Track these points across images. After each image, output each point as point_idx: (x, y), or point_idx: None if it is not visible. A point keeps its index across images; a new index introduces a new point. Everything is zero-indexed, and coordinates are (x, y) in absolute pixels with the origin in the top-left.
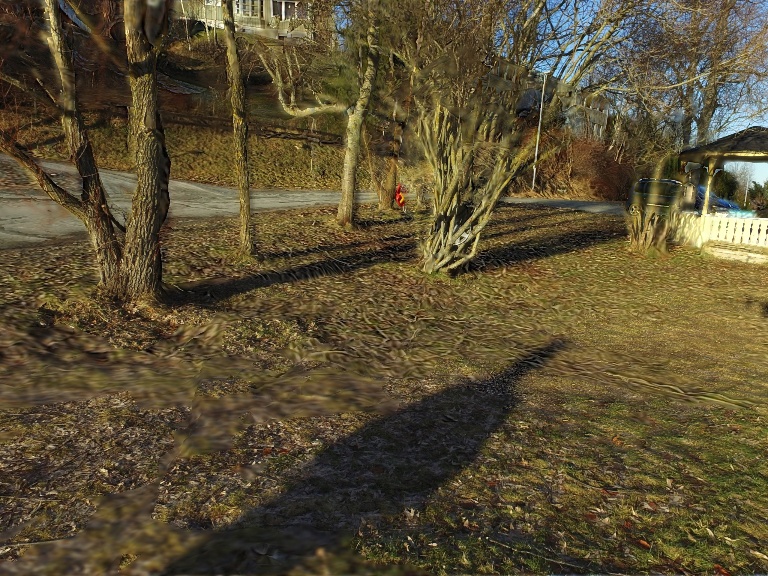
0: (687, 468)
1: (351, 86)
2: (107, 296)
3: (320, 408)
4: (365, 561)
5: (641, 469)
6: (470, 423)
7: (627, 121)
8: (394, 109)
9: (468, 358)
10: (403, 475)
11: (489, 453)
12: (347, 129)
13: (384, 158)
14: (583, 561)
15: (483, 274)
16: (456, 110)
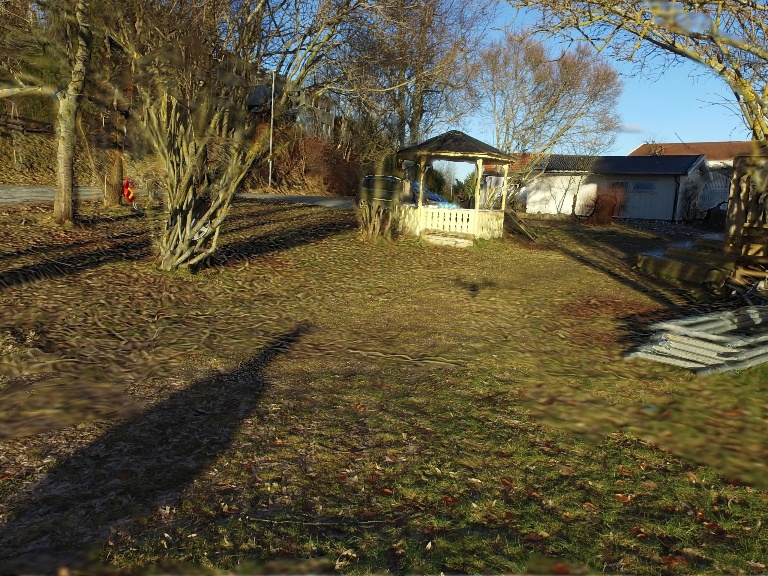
0: (418, 421)
1: (59, 68)
2: None
3: (50, 422)
4: (118, 569)
5: (381, 429)
6: (222, 413)
7: (352, 122)
8: (114, 97)
9: (216, 351)
10: (155, 475)
11: (244, 438)
12: None
13: (106, 150)
14: (337, 518)
15: (226, 268)
16: (185, 102)
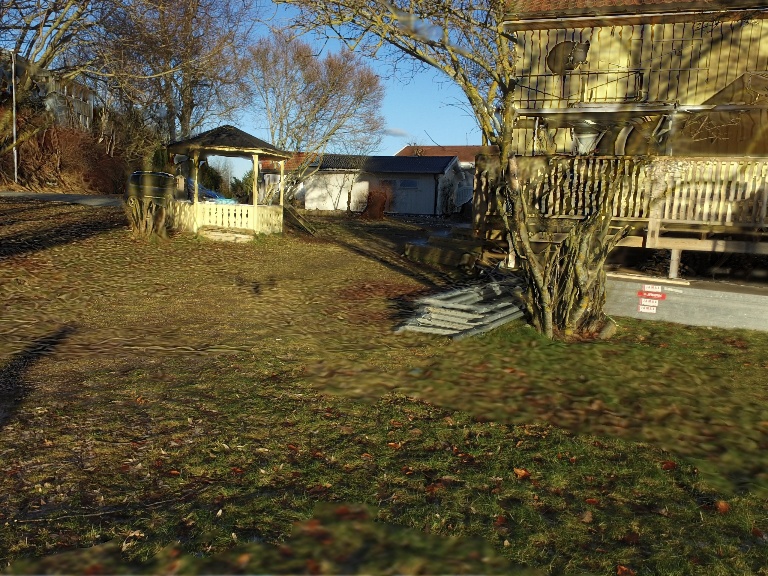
0: (204, 406)
1: None
2: None
3: None
4: None
5: (165, 417)
6: None
7: (114, 114)
8: None
9: None
10: None
11: (4, 446)
12: None
13: None
14: (122, 505)
15: None
16: None
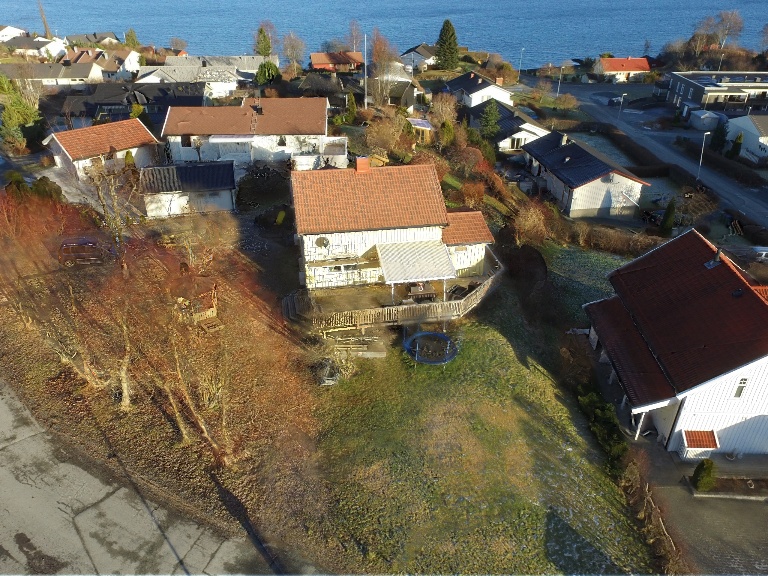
0: None
1: None
2: (233, 464)
3: None
4: None
5: None
6: None
7: None
8: None
9: None
10: None
11: None
12: (123, 377)
13: None
14: None
15: None
16: None
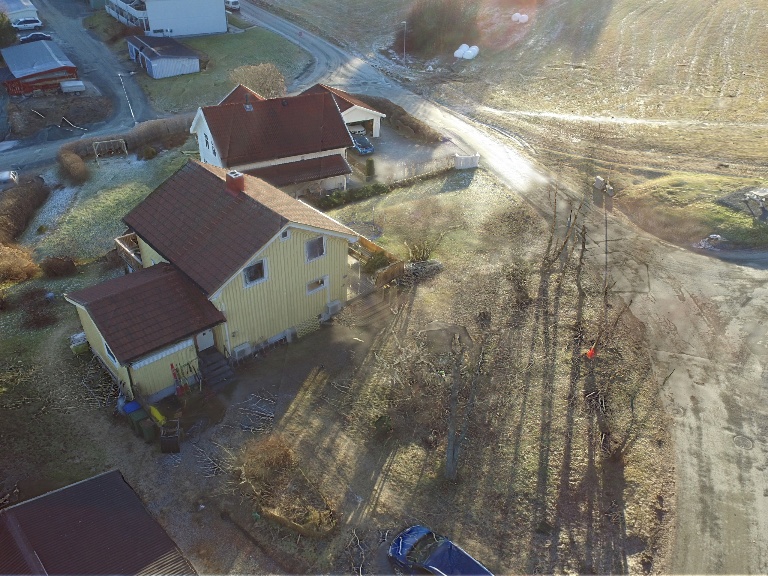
0: None
1: None
2: None
3: None
4: None
5: None
6: None
7: None
8: None
9: None
10: None
11: None
12: None
13: None
14: None
15: None
16: None
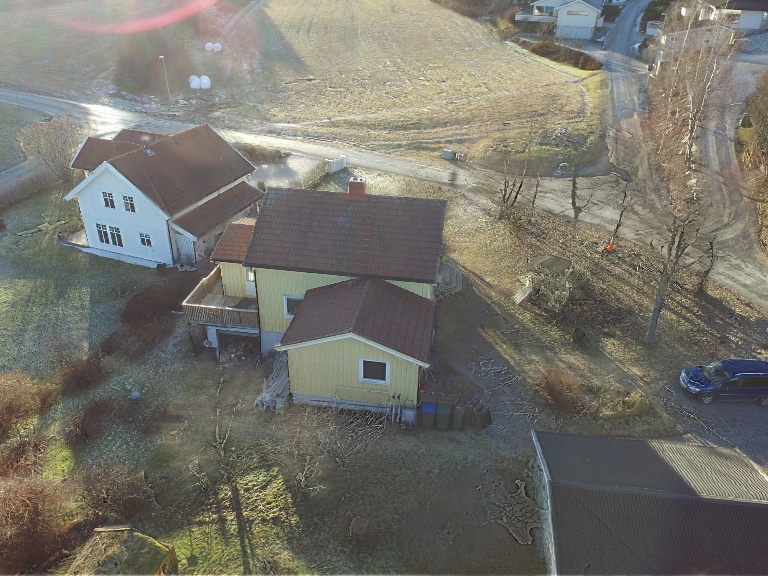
0: None
1: None
2: None
3: None
4: None
5: None
6: None
7: None
8: None
9: None
10: None
11: None
12: None
13: None
14: None
15: None
16: None
